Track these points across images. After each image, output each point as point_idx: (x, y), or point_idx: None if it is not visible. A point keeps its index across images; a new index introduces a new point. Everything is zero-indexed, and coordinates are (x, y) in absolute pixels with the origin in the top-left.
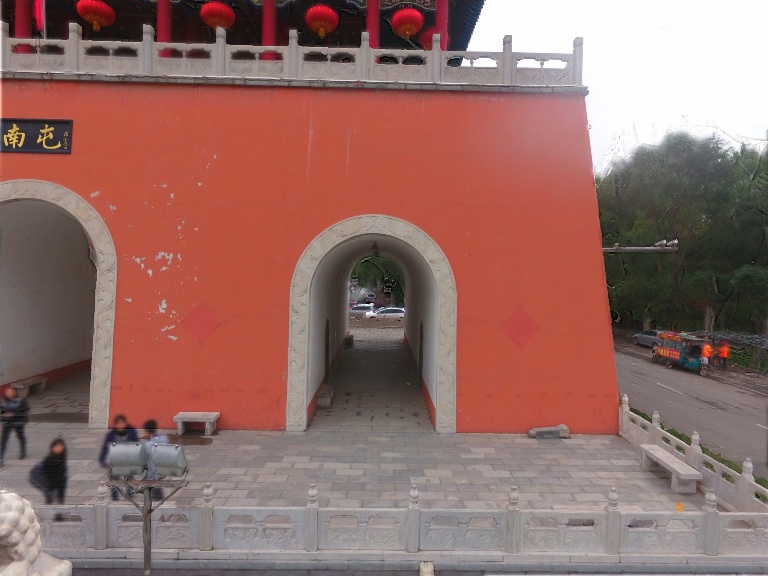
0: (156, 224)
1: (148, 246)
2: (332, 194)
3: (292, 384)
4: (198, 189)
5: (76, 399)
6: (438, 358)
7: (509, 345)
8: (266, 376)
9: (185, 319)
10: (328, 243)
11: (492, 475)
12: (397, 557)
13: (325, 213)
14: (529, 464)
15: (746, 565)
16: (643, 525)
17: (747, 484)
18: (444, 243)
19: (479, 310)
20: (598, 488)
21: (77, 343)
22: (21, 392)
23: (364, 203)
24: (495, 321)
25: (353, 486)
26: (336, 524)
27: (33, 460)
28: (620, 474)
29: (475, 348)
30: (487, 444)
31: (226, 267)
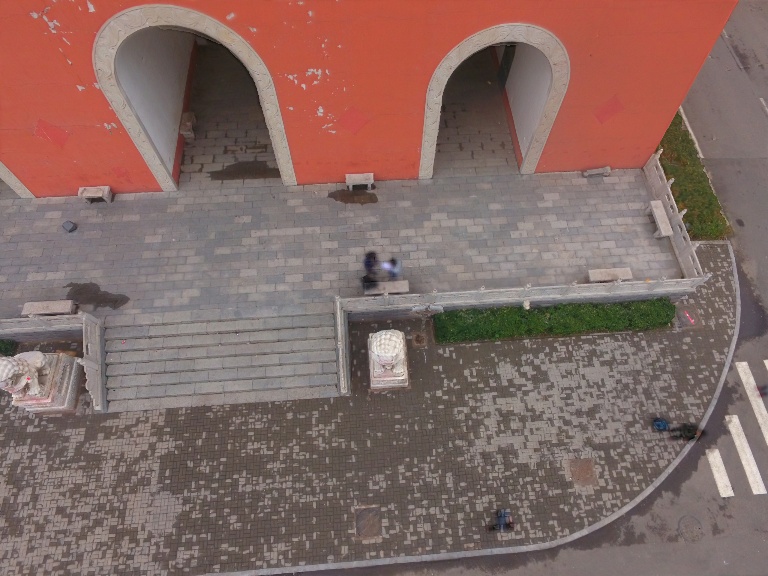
0: (300, 43)
1: (296, 63)
2: (475, 2)
3: (424, 155)
4: (336, 5)
5: (235, 137)
6: (536, 133)
7: (594, 122)
8: (405, 151)
9: (340, 119)
10: (464, 53)
11: (557, 226)
12: (514, 300)
13: (465, 23)
14: (579, 212)
15: (663, 292)
16: (627, 280)
17: (691, 251)
18: (572, 46)
19: (581, 99)
20: (614, 236)
21: (180, 57)
22: (189, 135)
23: (505, 10)
24: (590, 106)
25: (481, 243)
26: (490, 293)
27: (284, 230)
28: (630, 220)
29: (566, 124)
30: (554, 188)
31: (370, 78)
